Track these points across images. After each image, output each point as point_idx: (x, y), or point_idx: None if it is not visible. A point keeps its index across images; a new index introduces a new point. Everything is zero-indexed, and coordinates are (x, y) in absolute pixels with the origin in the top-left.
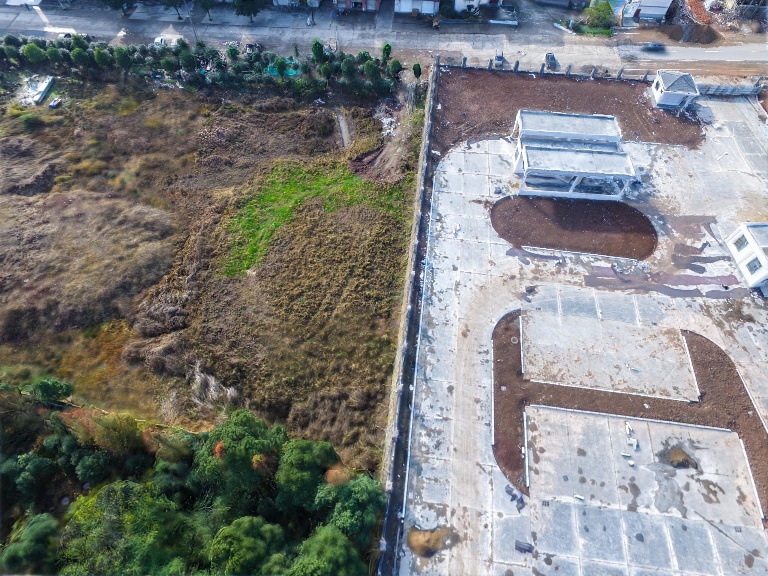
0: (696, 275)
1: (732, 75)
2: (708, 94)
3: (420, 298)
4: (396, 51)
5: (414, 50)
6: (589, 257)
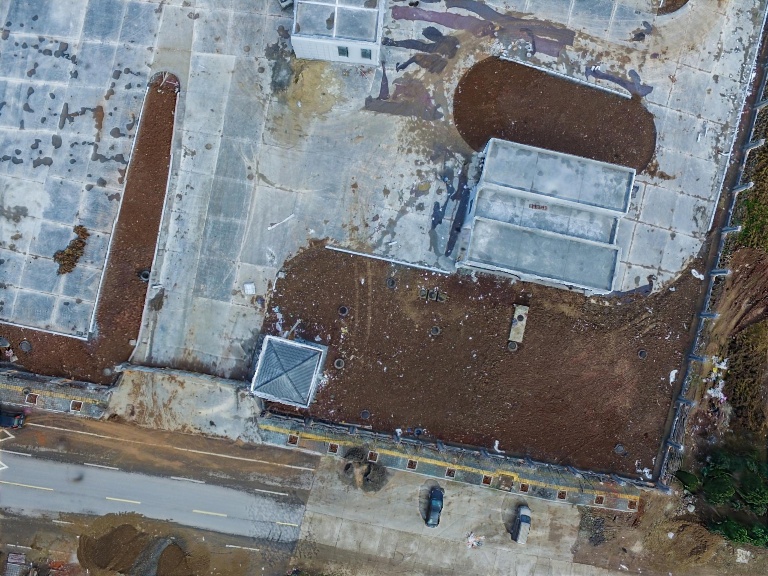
0: (439, 25)
1: (133, 426)
2: (212, 375)
3: (760, 47)
4: (681, 574)
5: (651, 574)
6: (556, 69)
